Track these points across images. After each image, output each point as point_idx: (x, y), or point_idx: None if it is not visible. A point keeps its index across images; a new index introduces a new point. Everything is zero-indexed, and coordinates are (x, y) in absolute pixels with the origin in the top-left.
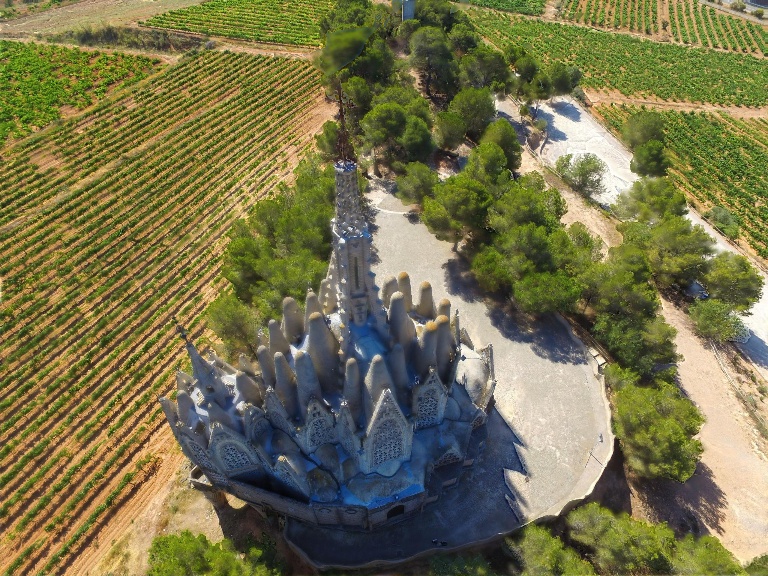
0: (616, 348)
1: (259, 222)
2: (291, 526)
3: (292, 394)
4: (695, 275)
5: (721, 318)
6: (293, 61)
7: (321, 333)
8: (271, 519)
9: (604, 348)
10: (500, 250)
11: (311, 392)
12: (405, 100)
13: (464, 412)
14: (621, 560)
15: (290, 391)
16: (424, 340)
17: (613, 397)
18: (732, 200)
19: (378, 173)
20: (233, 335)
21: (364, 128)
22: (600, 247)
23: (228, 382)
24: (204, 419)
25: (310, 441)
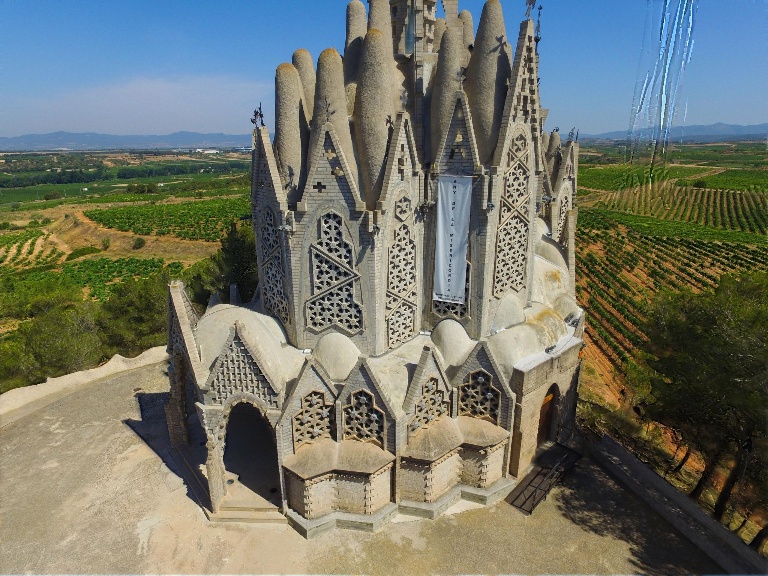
0: None
1: None
2: None
3: None
4: None
5: None
6: None
7: None
8: None
9: None
10: None
11: None
12: None
13: None
14: None
15: None
16: None
17: None
18: None
19: None
20: None
21: None
22: None
23: None
24: None
25: None
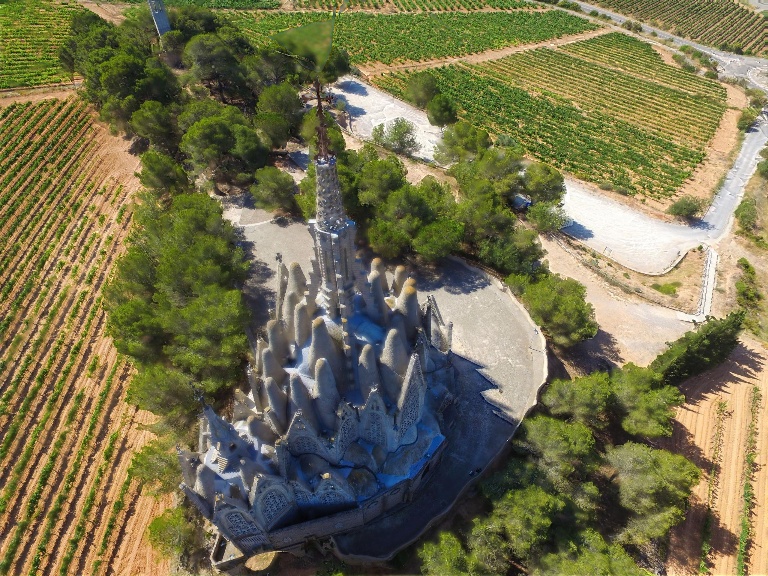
0: (502, 264)
1: (126, 282)
2: (340, 543)
3: (312, 411)
4: (516, 190)
5: (549, 214)
6: (38, 105)
7: (326, 337)
8: (310, 553)
9: (491, 268)
10: (383, 220)
11: (335, 397)
12: (214, 112)
13: (436, 361)
14: (593, 408)
15: (310, 408)
16: (406, 306)
17: (522, 300)
18: (504, 127)
19: (219, 192)
20: (169, 406)
21: (189, 150)
22: (449, 191)
23: (239, 434)
24: (235, 481)
25: (340, 448)
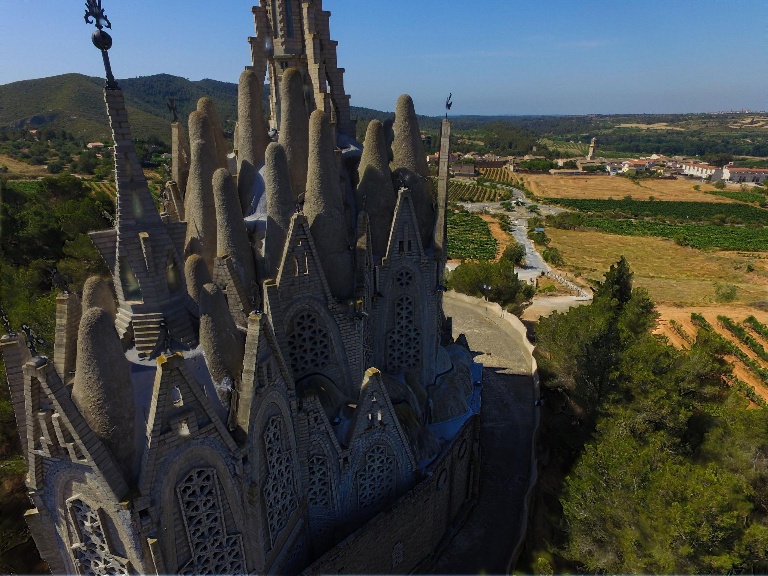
0: None
1: None
2: None
3: None
4: None
5: None
6: None
7: (306, 112)
8: None
9: None
10: None
11: (344, 215)
12: None
13: None
14: None
15: None
16: None
17: None
18: None
19: None
20: None
21: None
22: None
23: None
24: None
25: (363, 354)
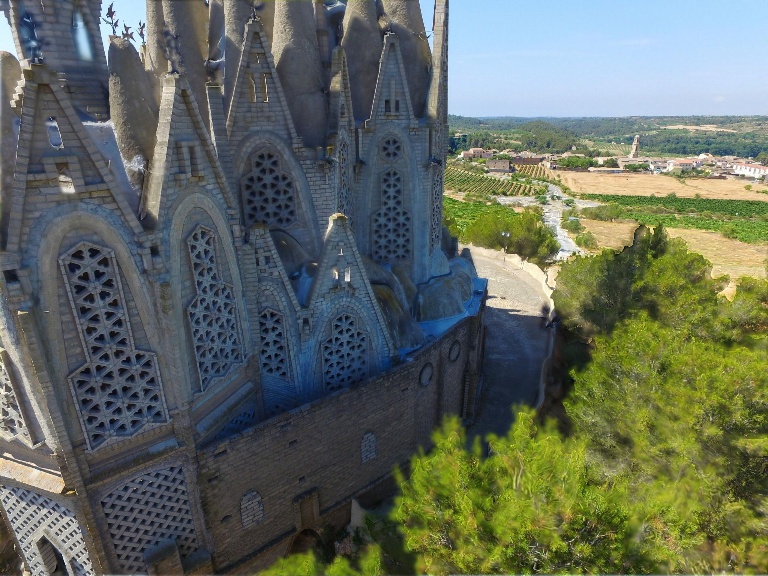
0: None
1: None
2: None
3: None
4: None
5: None
6: None
7: None
8: None
9: None
10: None
11: (318, 53)
12: None
13: None
14: None
15: None
16: None
17: None
18: None
19: None
20: None
21: None
22: None
23: None
24: None
25: None
